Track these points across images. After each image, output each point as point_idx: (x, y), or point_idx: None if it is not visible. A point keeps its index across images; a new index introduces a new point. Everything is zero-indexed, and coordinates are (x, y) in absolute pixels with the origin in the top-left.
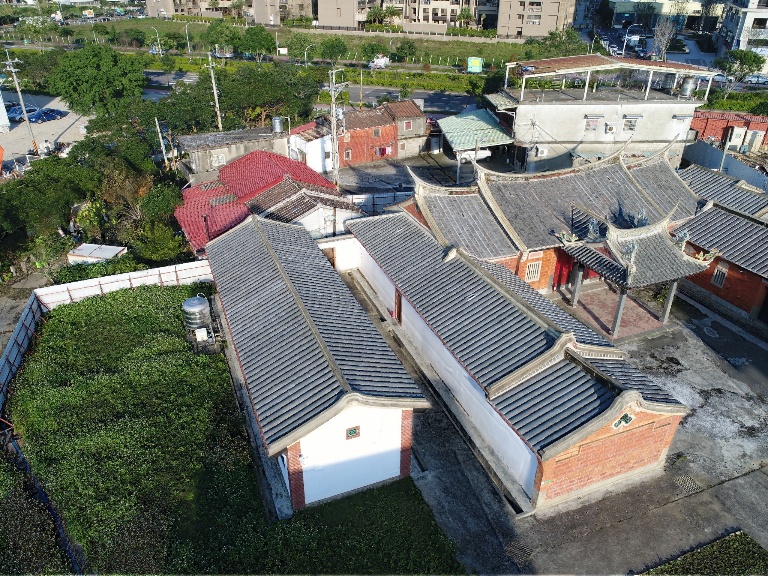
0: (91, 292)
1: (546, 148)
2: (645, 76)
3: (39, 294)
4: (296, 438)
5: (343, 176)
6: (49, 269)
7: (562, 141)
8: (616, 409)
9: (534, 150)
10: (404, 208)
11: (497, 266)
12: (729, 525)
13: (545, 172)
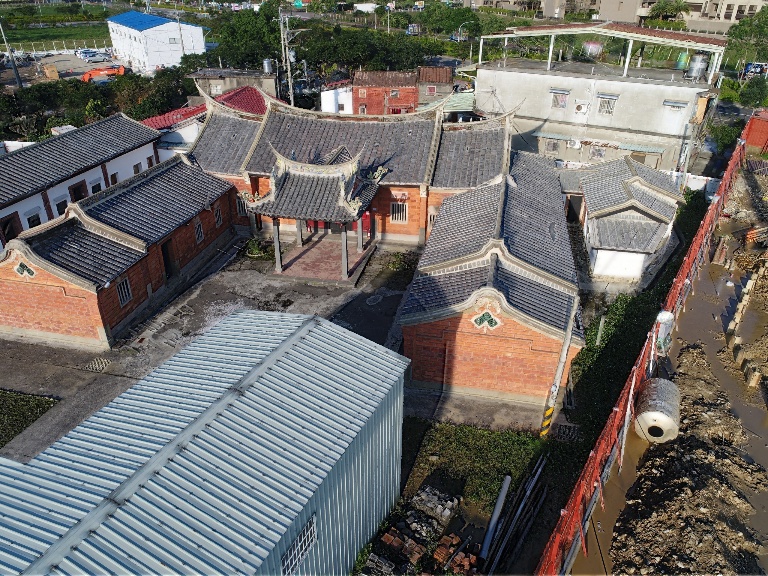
0: None
1: None
2: (623, 45)
3: (7, 145)
4: None
5: None
6: None
7: (525, 116)
8: None
9: None
10: None
11: (217, 180)
12: (60, 394)
13: None
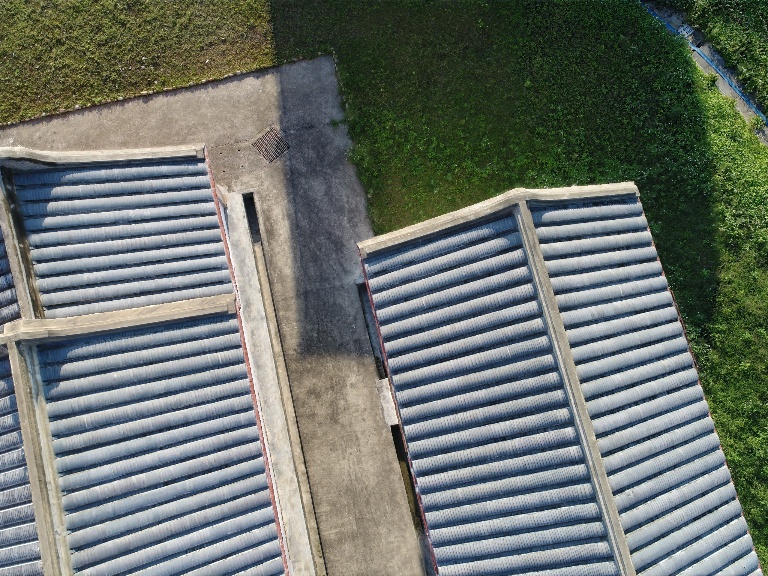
0: None
1: None
2: None
3: None
4: (599, 187)
5: None
6: None
7: None
8: None
9: None
10: None
11: None
12: None
13: None
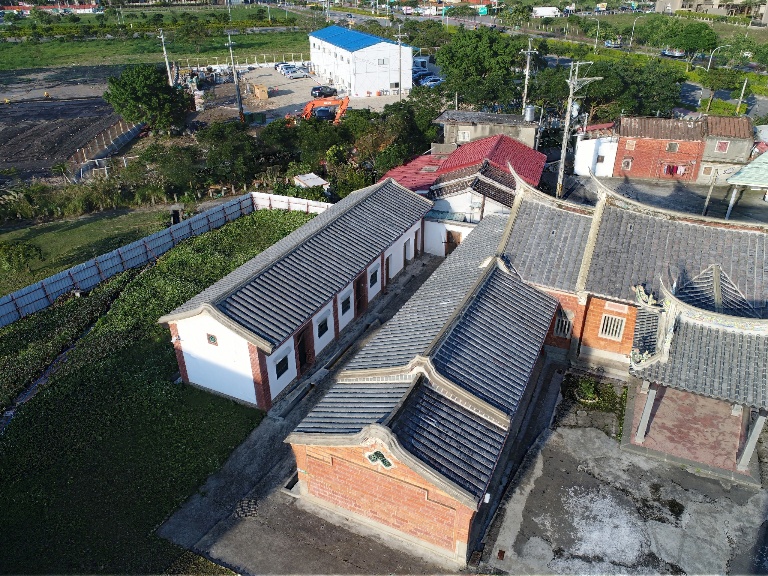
0: (284, 206)
1: None
2: None
3: (254, 196)
4: (172, 319)
5: None
6: None
7: None
8: (361, 436)
9: None
10: None
11: (540, 295)
12: None
13: None
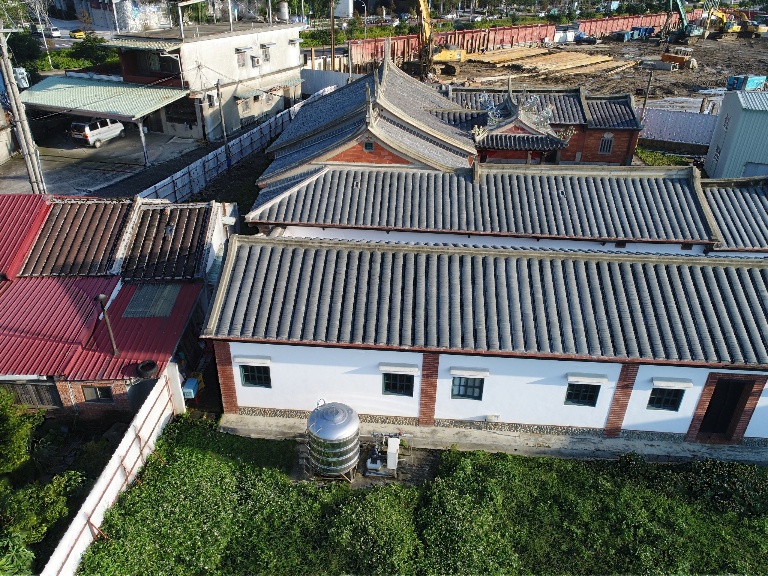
0: None
1: None
2: None
3: None
4: None
5: None
6: None
7: (226, 83)
8: None
9: (206, 100)
10: (329, 160)
11: None
12: None
13: (383, 83)
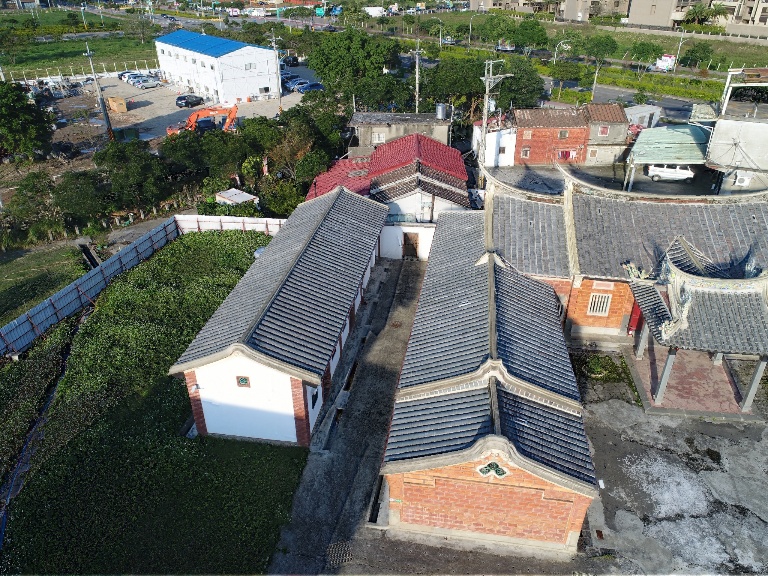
0: (214, 227)
1: (748, 176)
2: None
3: (178, 219)
4: (190, 367)
5: (510, 173)
6: (197, 202)
7: None
8: (476, 451)
9: (733, 176)
10: None
11: (538, 284)
12: None
13: None
